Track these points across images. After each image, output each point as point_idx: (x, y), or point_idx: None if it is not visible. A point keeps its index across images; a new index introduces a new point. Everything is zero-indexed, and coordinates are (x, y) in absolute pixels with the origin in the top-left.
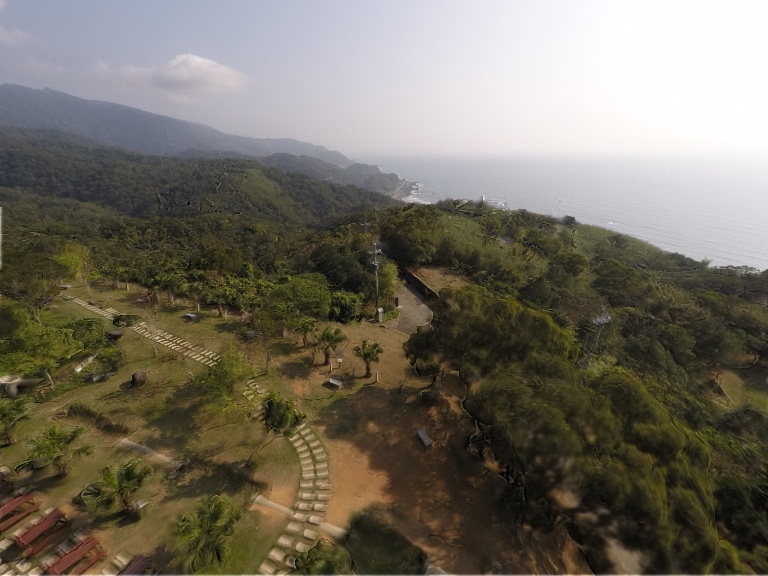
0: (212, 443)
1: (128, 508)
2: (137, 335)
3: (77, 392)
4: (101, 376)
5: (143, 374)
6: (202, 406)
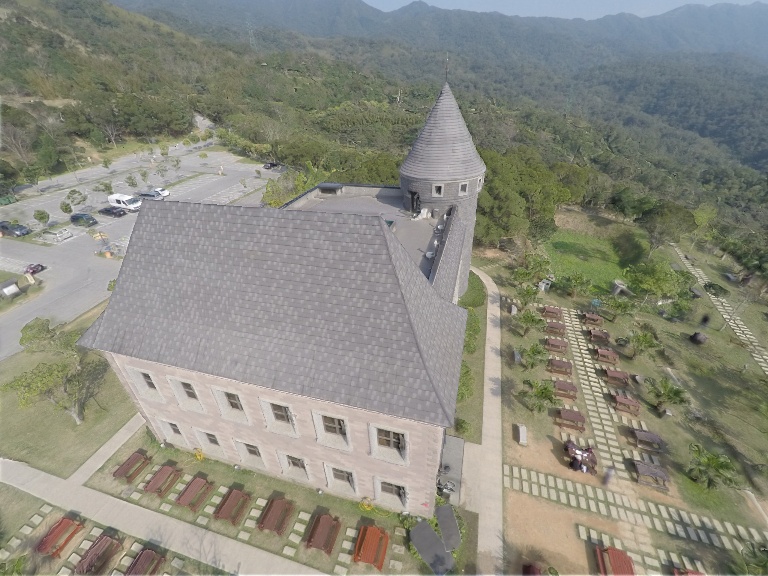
0: (731, 426)
1: (657, 406)
2: (711, 304)
3: (652, 317)
4: (668, 316)
5: (705, 338)
6: (738, 396)
